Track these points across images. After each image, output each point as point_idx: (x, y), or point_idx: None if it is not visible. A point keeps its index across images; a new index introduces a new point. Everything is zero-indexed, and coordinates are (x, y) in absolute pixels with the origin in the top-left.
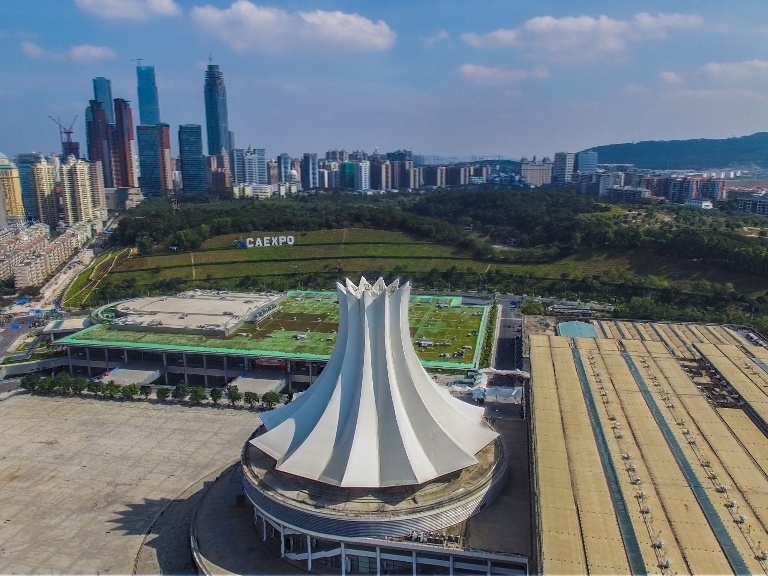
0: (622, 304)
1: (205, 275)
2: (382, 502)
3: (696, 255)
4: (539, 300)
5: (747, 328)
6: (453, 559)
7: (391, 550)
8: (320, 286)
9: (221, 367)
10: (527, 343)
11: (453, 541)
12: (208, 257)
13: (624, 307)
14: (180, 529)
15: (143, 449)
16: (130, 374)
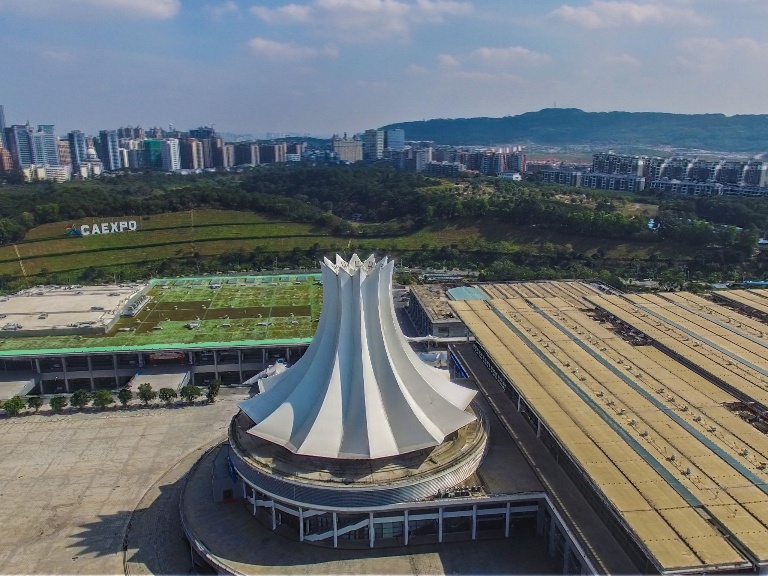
0: (486, 269)
1: (38, 269)
2: (405, 468)
3: (535, 221)
4: (408, 271)
5: (597, 281)
6: (477, 508)
7: (420, 511)
8: (177, 273)
9: (108, 367)
10: (430, 310)
11: (476, 491)
12: (36, 249)
13: (489, 271)
14: (160, 538)
15: (65, 465)
16: None
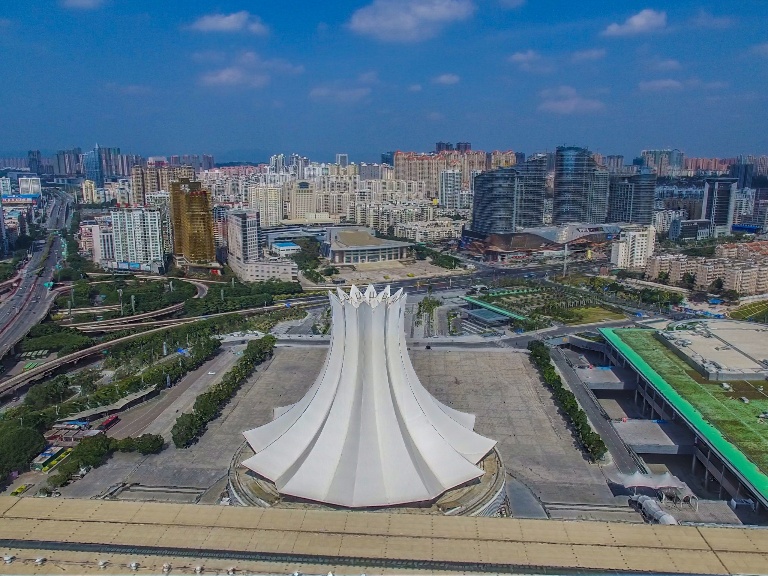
0: None
1: None
2: None
3: None
4: None
5: None
6: None
7: None
8: None
9: None
10: None
11: None
12: None
13: None
14: None
15: None
16: (604, 375)
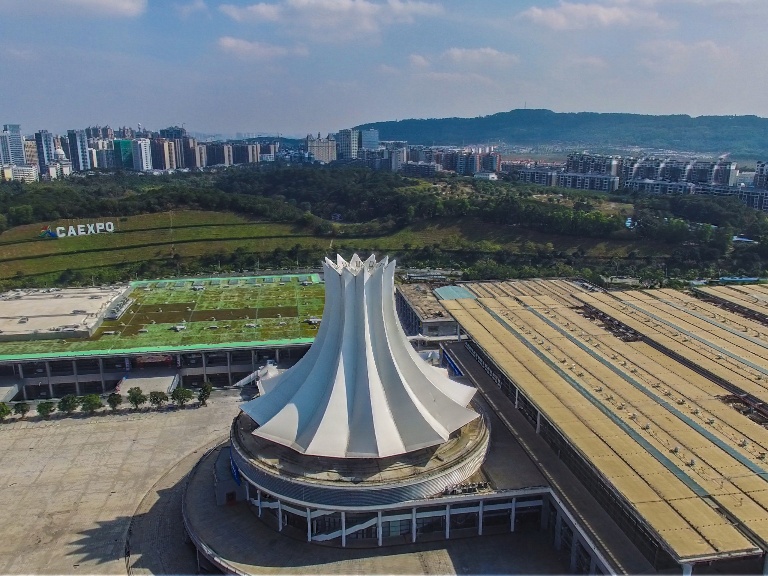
0: (469, 268)
1: (13, 272)
2: (412, 466)
3: (515, 221)
4: None
5: (579, 279)
6: (483, 503)
7: (427, 508)
8: (157, 274)
9: (94, 371)
10: (419, 309)
11: (483, 487)
12: (10, 251)
13: (472, 270)
14: (162, 543)
15: (57, 472)
16: None
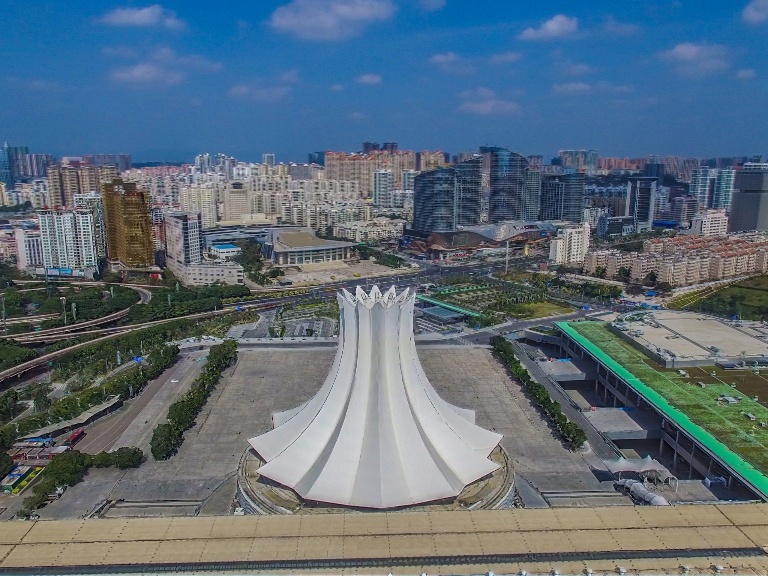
0: None
1: None
2: None
3: None
4: None
5: None
6: None
7: None
8: None
9: None
10: None
11: None
12: None
13: None
14: None
15: None
16: (565, 367)
